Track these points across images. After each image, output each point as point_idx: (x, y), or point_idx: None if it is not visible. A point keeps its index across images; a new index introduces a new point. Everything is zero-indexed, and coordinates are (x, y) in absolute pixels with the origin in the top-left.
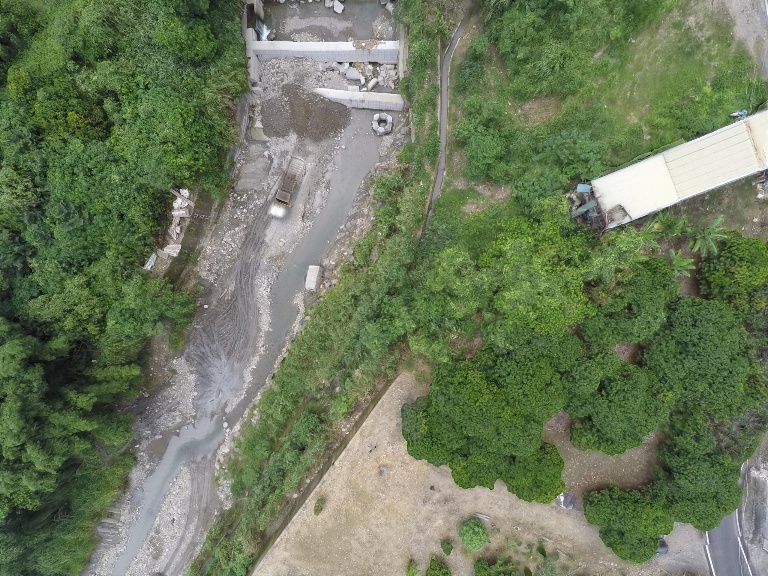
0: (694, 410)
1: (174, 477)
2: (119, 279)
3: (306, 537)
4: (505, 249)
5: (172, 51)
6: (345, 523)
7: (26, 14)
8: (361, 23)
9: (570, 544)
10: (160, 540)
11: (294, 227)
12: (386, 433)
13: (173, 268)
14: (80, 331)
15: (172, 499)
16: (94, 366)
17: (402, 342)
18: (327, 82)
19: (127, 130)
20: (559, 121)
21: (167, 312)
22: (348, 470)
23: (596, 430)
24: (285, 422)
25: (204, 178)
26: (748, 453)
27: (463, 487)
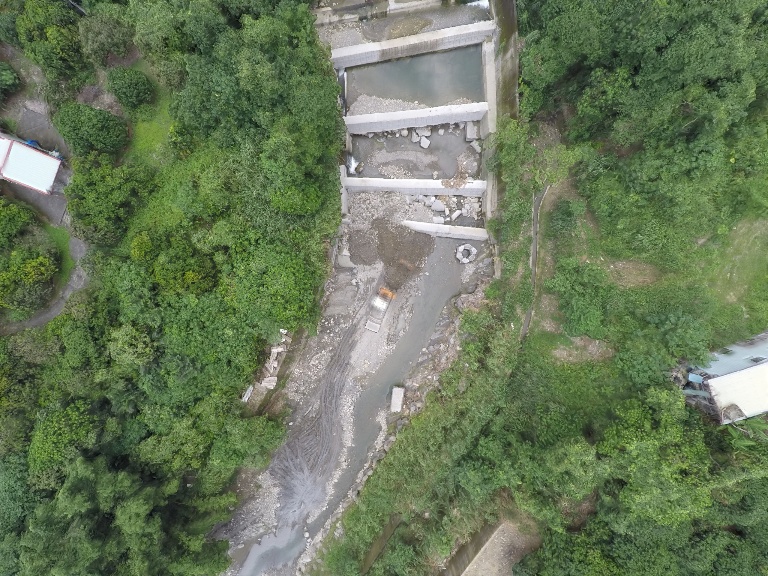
0: None
1: None
2: (221, 415)
3: None
4: (631, 449)
5: None
6: None
7: (147, 179)
8: (446, 157)
9: None
10: None
11: (379, 350)
12: None
13: (267, 396)
14: (185, 468)
15: None
16: (194, 496)
17: (503, 490)
18: (413, 213)
19: (236, 281)
20: (660, 293)
21: (266, 446)
22: None
23: None
24: (371, 540)
25: (303, 318)
26: None
27: None
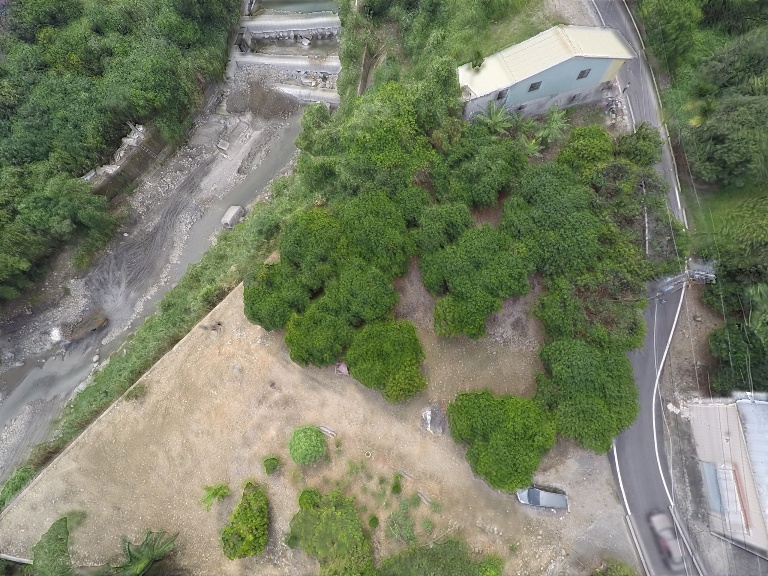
0: (561, 283)
1: (14, 418)
2: None
3: (108, 444)
4: (358, 102)
5: (164, 30)
6: (160, 427)
7: (72, 2)
8: (321, 52)
9: (437, 489)
10: None
11: (229, 176)
12: (238, 318)
13: (106, 187)
14: None
15: None
16: None
17: None
18: (285, 82)
19: None
20: None
21: (79, 211)
22: (184, 356)
23: (453, 299)
24: None
25: (159, 117)
26: (633, 341)
27: (295, 356)
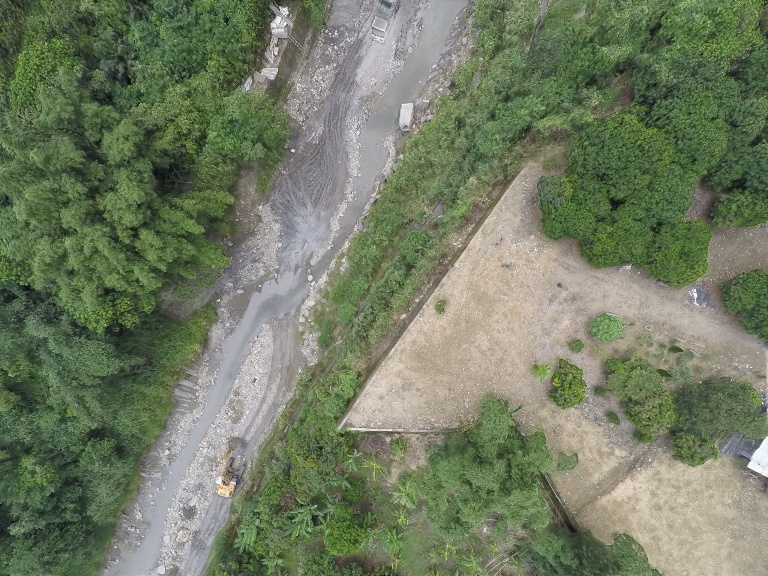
0: None
1: (255, 336)
2: (218, 96)
3: (422, 347)
4: None
5: None
6: (465, 329)
7: None
8: None
9: (703, 345)
10: (240, 403)
11: (386, 65)
12: (510, 230)
13: None
14: (179, 146)
15: (253, 358)
16: (189, 191)
17: (524, 138)
18: None
19: None
20: None
21: (266, 132)
22: (469, 270)
23: (749, 193)
24: (380, 262)
25: None
26: None
27: (606, 260)
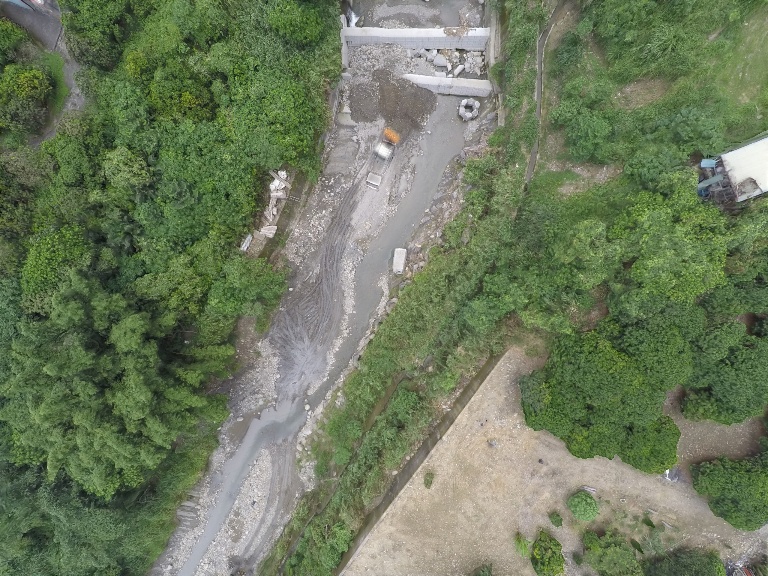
0: None
1: (254, 460)
2: (219, 259)
3: (412, 512)
4: (643, 220)
5: (282, 34)
6: (452, 497)
7: None
8: (448, 11)
9: (674, 516)
10: (239, 523)
11: (380, 211)
12: (494, 407)
13: (266, 250)
14: (182, 310)
15: (252, 482)
16: (191, 346)
17: (509, 318)
18: (415, 68)
19: (235, 111)
20: (669, 102)
21: (265, 292)
22: (456, 444)
23: (715, 400)
24: (373, 402)
25: (303, 160)
26: None
27: (583, 457)
